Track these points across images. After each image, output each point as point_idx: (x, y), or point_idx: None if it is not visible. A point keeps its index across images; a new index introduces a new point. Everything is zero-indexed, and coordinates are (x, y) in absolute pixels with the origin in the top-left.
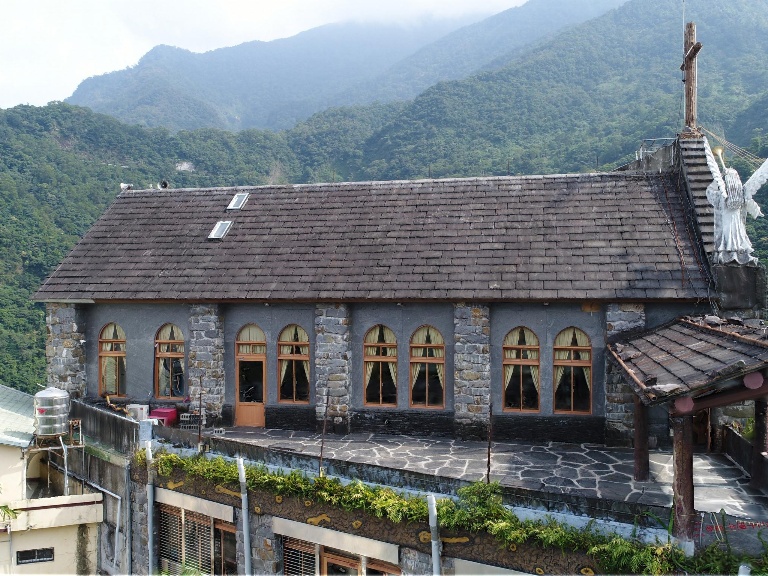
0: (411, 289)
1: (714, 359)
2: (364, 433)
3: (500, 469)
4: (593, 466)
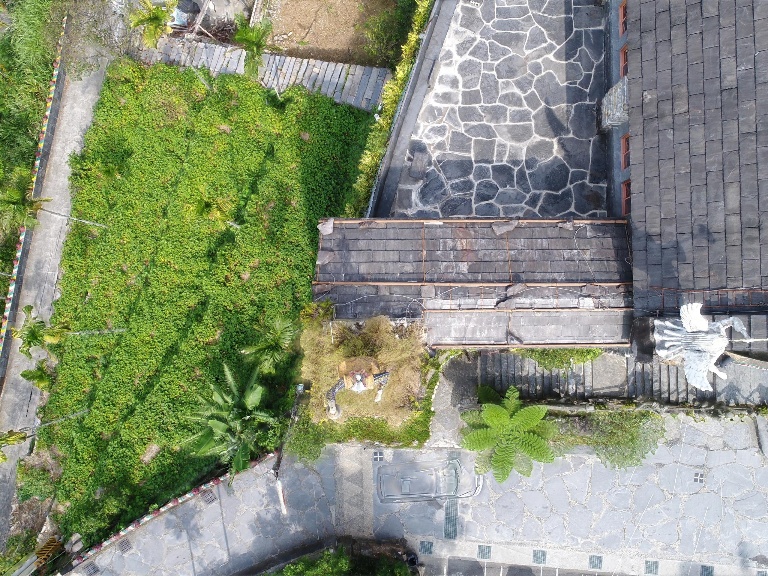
0: (641, 7)
1: (377, 261)
2: (604, 19)
3: (510, 149)
4: (533, 216)
